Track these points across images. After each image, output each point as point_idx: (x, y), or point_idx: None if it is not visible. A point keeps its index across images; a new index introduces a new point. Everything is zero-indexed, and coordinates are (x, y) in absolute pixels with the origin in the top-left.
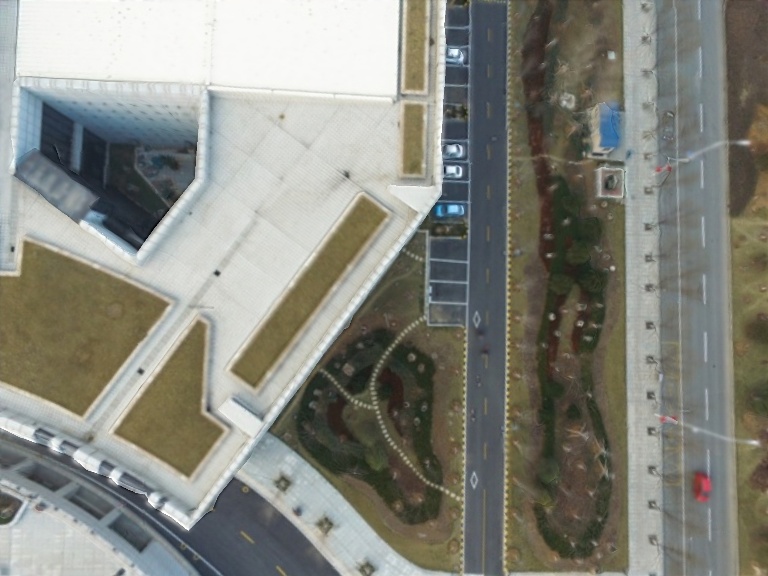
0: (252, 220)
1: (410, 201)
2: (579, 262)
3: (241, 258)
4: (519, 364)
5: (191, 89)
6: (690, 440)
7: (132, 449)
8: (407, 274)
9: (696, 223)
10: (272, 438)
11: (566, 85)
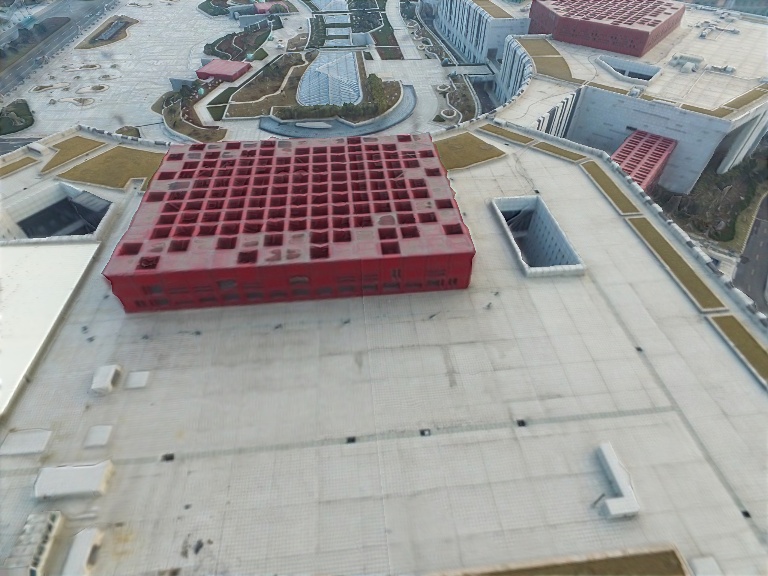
0: None
1: None
2: None
3: (7, 194)
4: None
5: None
6: None
7: None
8: None
9: None
10: None
11: None
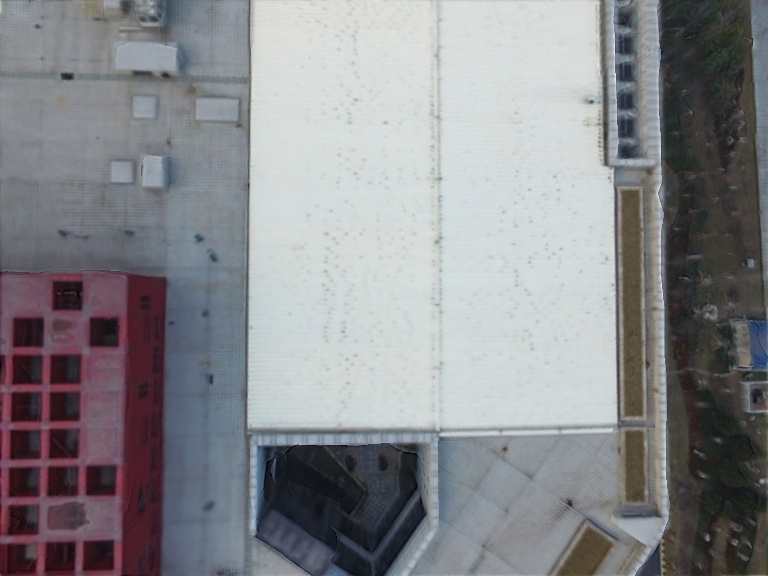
0: (480, 555)
1: (638, 535)
2: (735, 486)
3: None
4: None
5: (423, 437)
6: None
7: None
8: None
9: None
10: None
11: (709, 298)
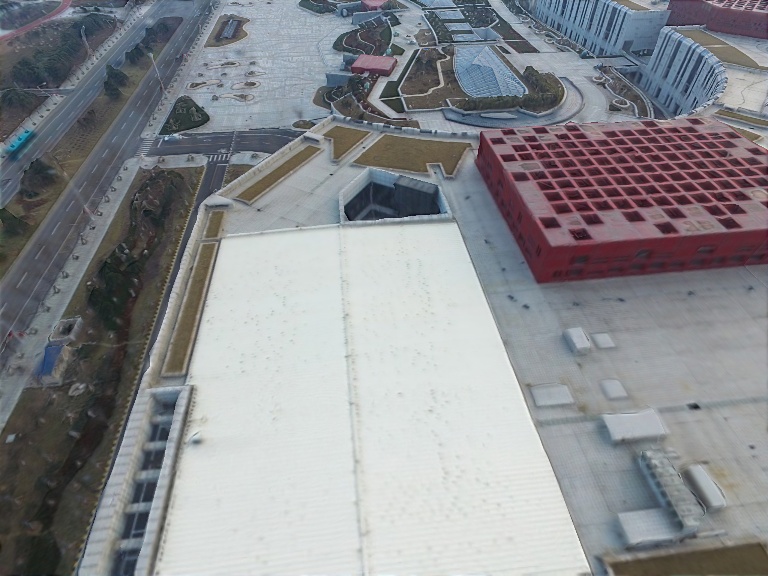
0: None
1: (221, 198)
2: (115, 273)
3: None
4: None
5: None
6: (76, 214)
7: (363, 130)
8: None
9: (3, 318)
10: None
11: None
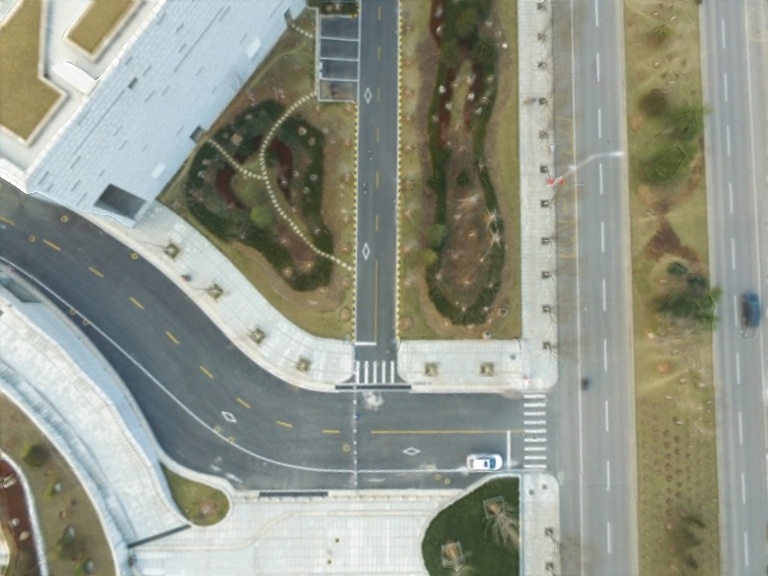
0: None
1: None
2: (466, 30)
3: None
4: (411, 138)
5: None
6: (584, 213)
7: None
8: (296, 49)
9: (590, 4)
10: (161, 207)
11: None
